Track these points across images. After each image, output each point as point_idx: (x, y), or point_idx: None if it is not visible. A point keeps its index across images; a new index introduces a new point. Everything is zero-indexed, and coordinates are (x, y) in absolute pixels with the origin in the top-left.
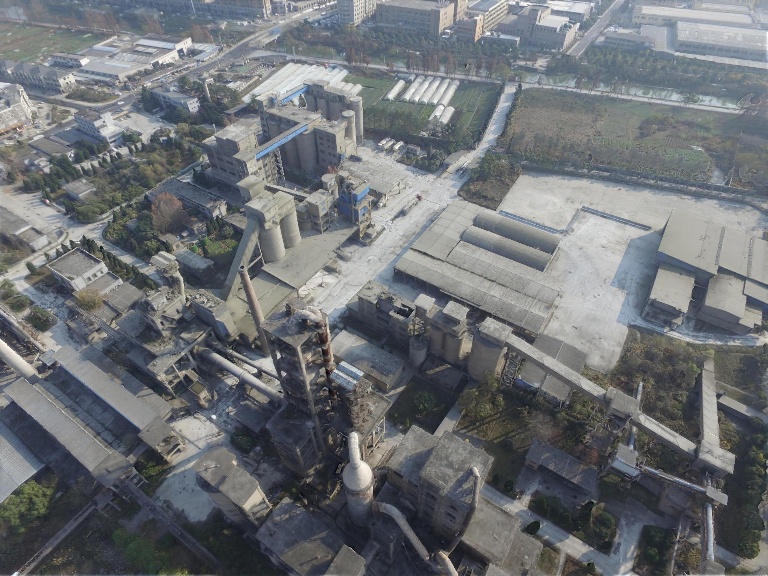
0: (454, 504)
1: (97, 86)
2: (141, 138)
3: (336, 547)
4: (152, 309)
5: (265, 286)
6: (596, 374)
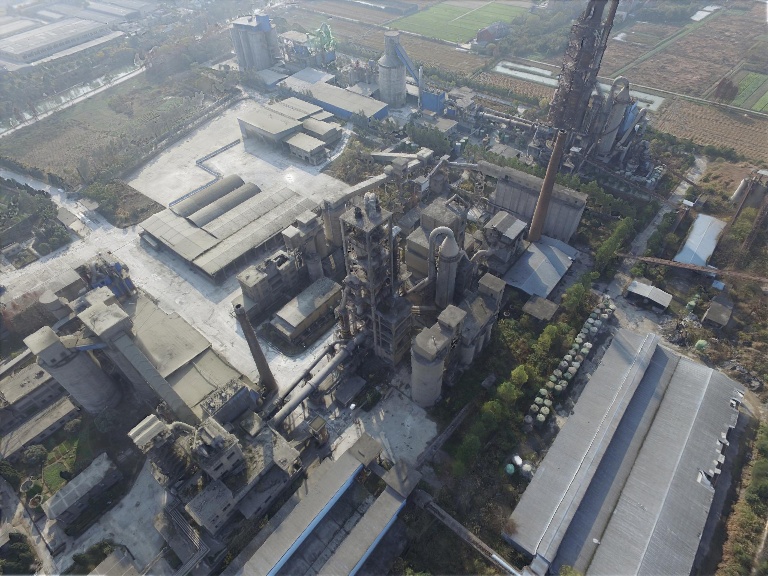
0: (463, 218)
1: None
2: None
3: (475, 296)
4: (222, 443)
5: (189, 379)
6: None
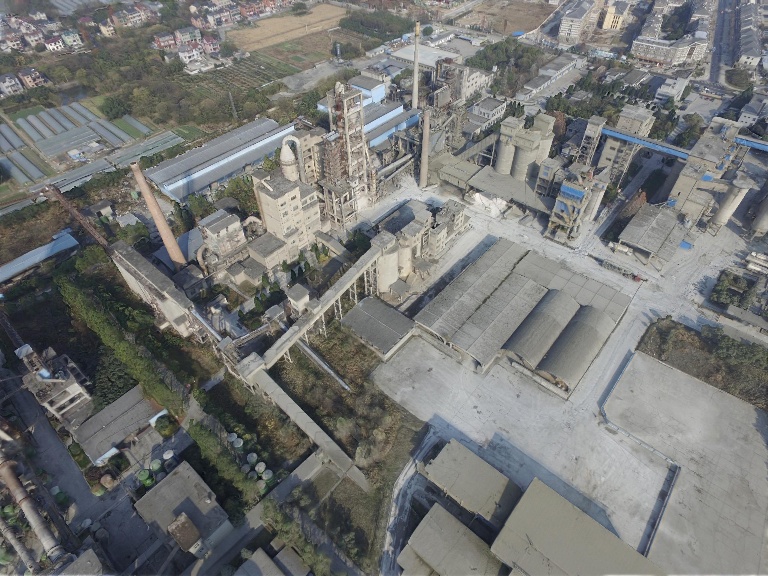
0: None
1: (761, 78)
2: (675, 110)
3: None
4: None
5: (472, 171)
6: None
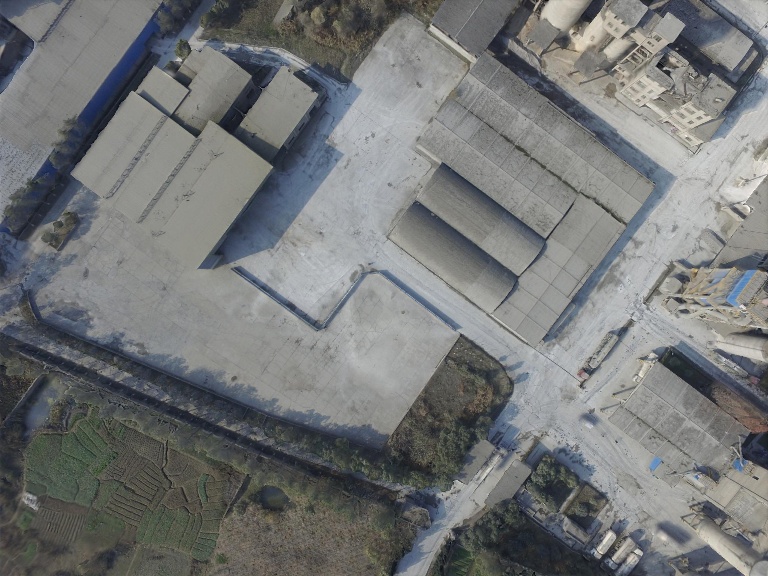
0: None
1: None
2: None
3: None
4: None
5: None
6: (423, 6)
